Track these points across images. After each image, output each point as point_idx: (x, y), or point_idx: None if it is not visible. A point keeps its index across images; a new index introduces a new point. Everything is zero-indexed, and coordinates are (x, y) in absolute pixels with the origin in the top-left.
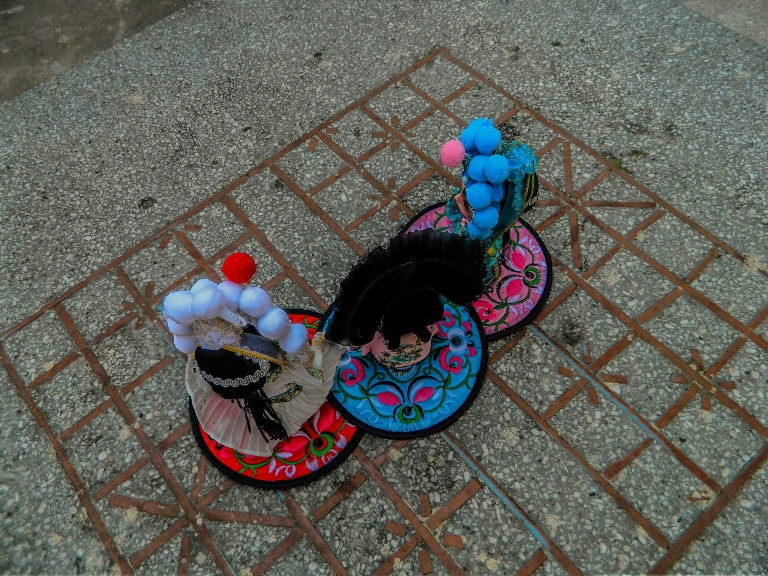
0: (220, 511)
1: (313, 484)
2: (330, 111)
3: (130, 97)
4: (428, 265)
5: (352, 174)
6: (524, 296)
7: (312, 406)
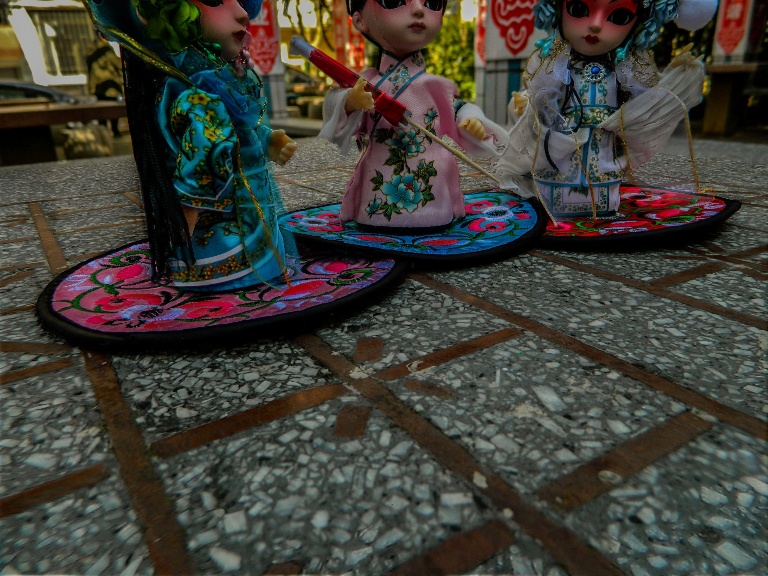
0: None
1: None
2: None
3: None
4: None
5: (529, 471)
6: None
7: None
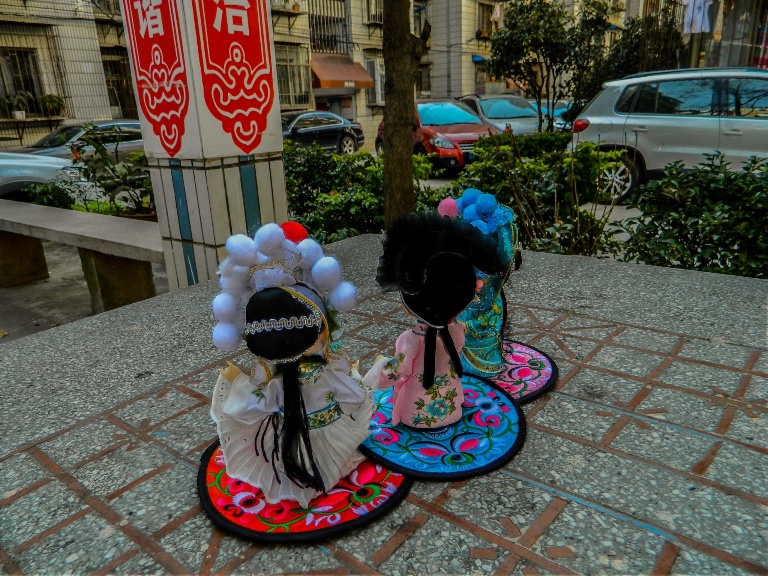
0: None
1: (364, 532)
2: None
3: (129, 328)
4: (454, 237)
5: (347, 339)
6: (536, 375)
7: (353, 435)
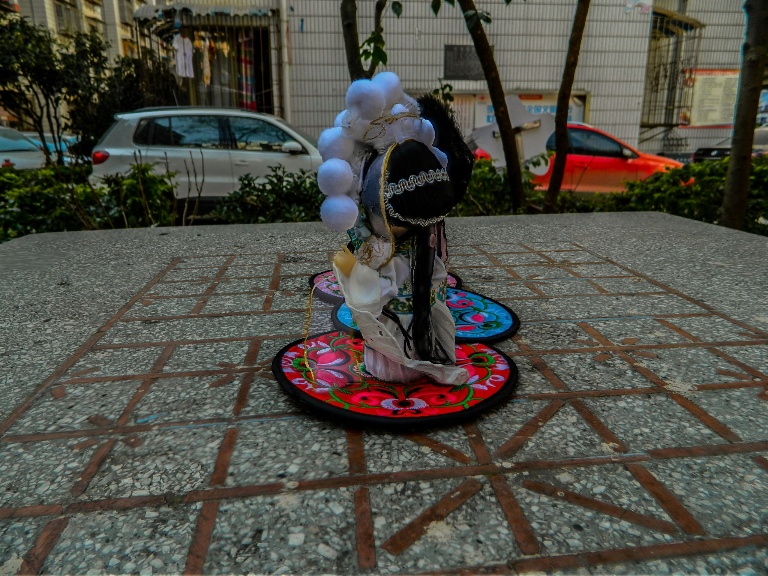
0: (506, 444)
1: (521, 381)
2: (131, 291)
3: None
4: None
5: (215, 297)
6: None
7: None
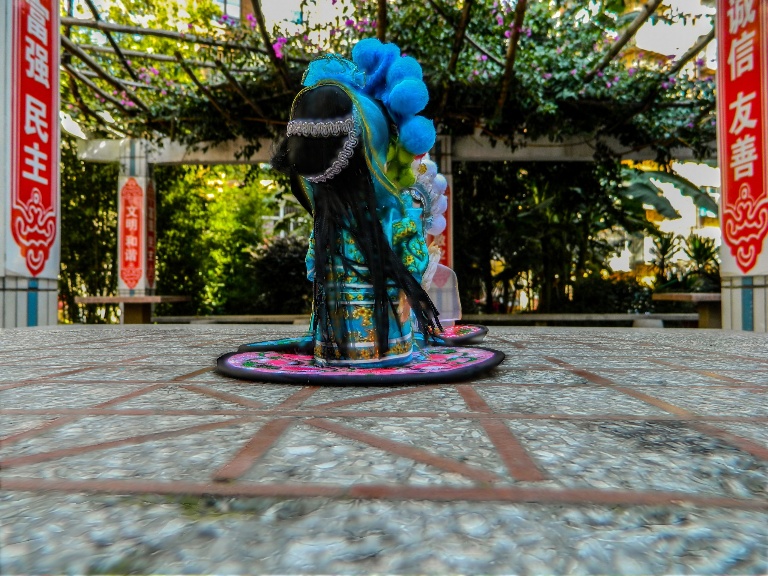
0: None
1: None
2: None
3: None
4: None
5: (664, 367)
6: None
7: None
